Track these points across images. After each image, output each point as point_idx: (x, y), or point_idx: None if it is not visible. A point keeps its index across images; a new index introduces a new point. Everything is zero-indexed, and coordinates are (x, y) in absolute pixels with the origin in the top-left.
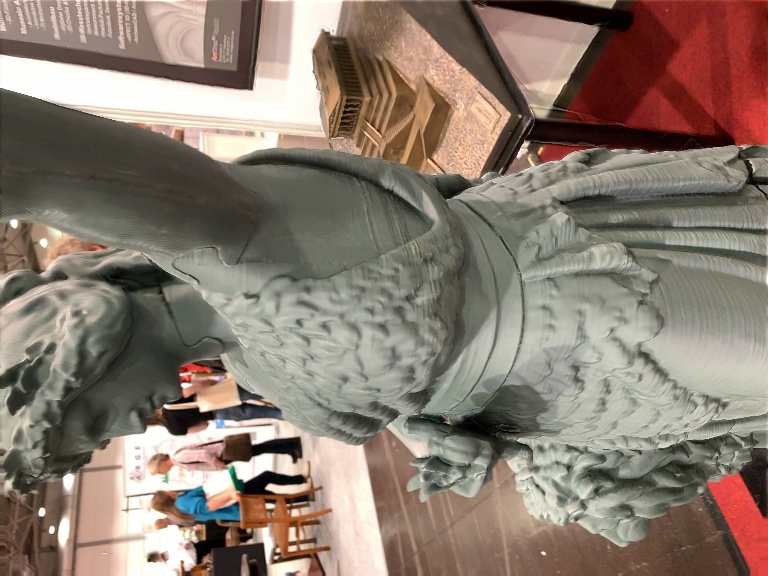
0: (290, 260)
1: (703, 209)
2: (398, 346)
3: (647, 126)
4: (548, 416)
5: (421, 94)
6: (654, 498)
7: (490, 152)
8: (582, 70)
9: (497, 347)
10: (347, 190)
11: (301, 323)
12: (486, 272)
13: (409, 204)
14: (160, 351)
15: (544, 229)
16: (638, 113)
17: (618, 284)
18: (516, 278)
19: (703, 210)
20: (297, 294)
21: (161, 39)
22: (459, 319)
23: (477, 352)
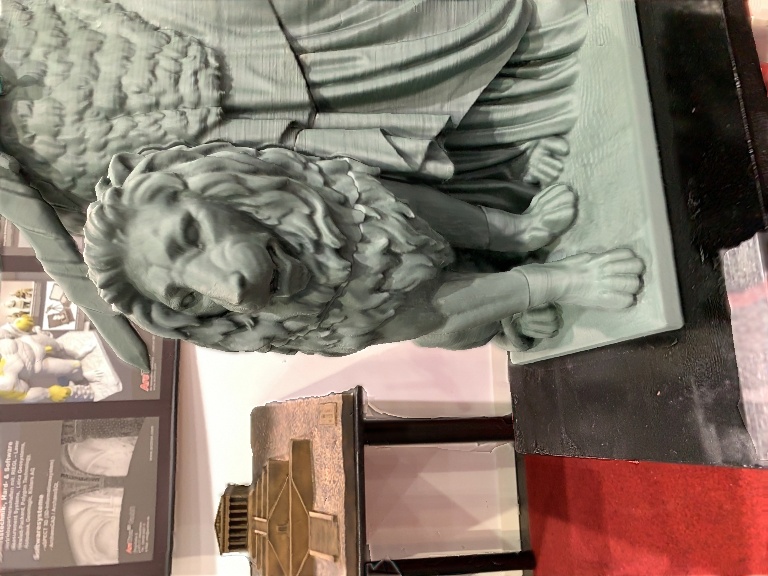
0: None
1: None
2: None
3: (579, 475)
4: (10, 47)
5: None
6: (202, 158)
7: (341, 443)
8: (522, 490)
9: None
10: None
11: None
12: None
13: None
14: None
15: None
16: (569, 473)
17: None
18: None
19: None
20: None
21: (76, 538)
22: None
23: None
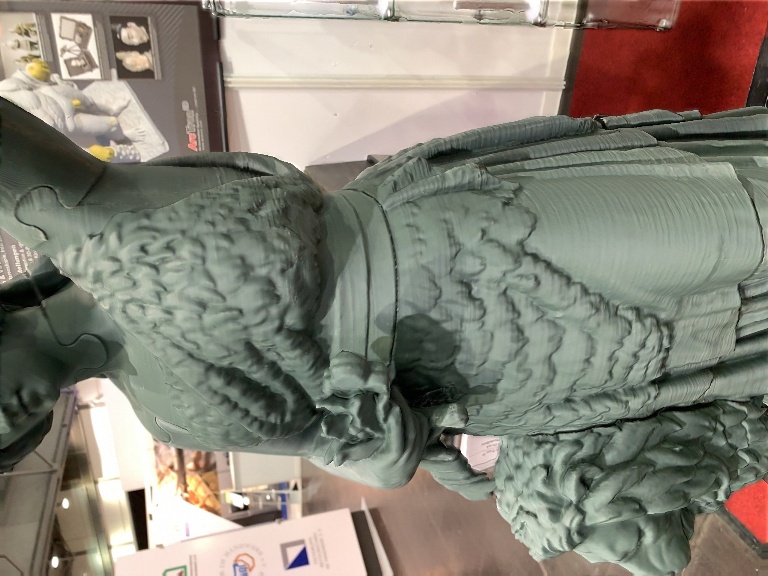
0: (134, 203)
1: (556, 141)
2: (246, 254)
3: None
4: (465, 358)
5: None
6: (658, 480)
7: None
8: None
9: (374, 274)
10: (203, 170)
11: (146, 251)
12: (346, 210)
13: (264, 174)
14: (31, 348)
15: (398, 171)
16: None
17: (479, 194)
18: (377, 209)
19: (556, 142)
20: (137, 221)
21: None
22: (323, 248)
23: (353, 281)
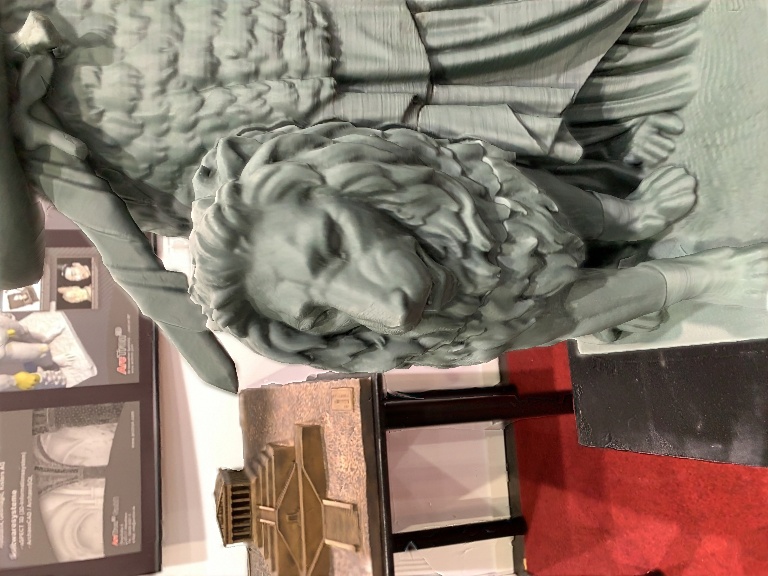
0: None
1: None
2: None
3: (578, 444)
4: None
5: (295, 438)
6: (335, 144)
7: (361, 430)
8: (511, 458)
9: None
10: None
11: None
12: None
13: None
14: None
15: None
16: (565, 443)
17: None
18: None
19: None
20: None
21: (56, 533)
22: None
23: None
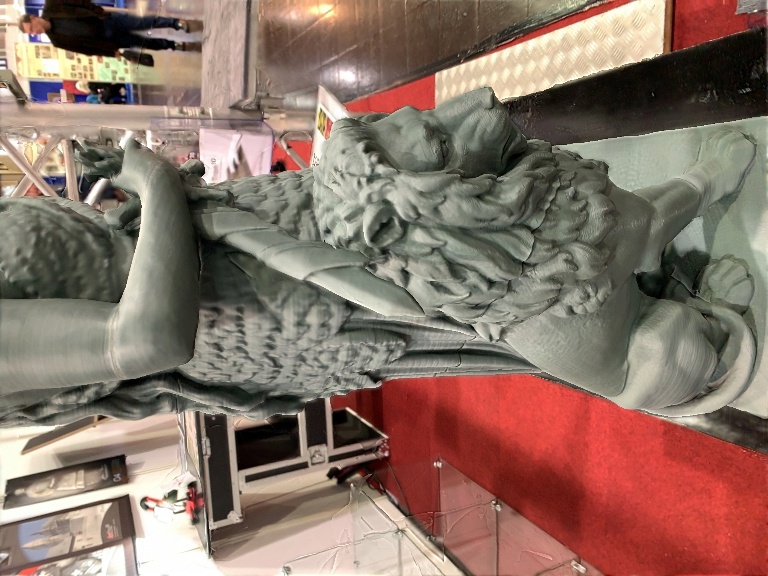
0: None
1: None
2: None
3: None
4: None
5: None
6: None
7: None
8: None
9: None
10: None
11: None
12: None
13: None
14: None
15: None
16: None
17: None
18: None
19: None
20: None
21: None
22: None
23: None
